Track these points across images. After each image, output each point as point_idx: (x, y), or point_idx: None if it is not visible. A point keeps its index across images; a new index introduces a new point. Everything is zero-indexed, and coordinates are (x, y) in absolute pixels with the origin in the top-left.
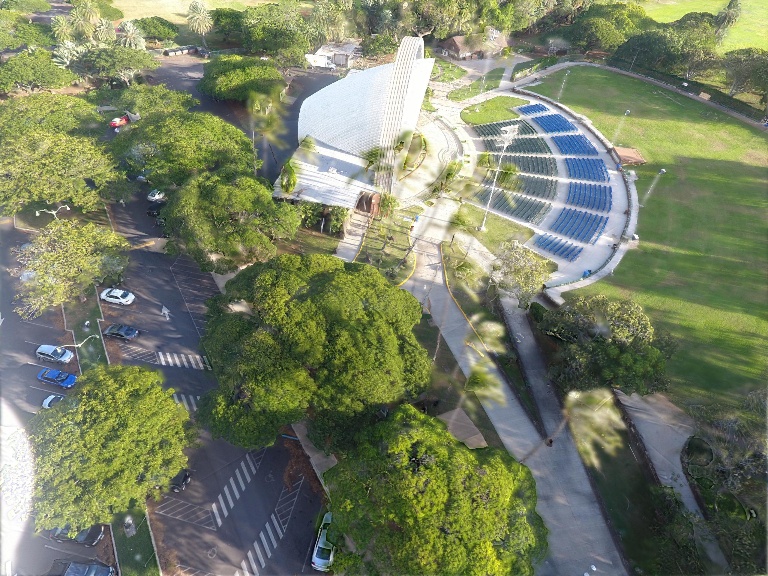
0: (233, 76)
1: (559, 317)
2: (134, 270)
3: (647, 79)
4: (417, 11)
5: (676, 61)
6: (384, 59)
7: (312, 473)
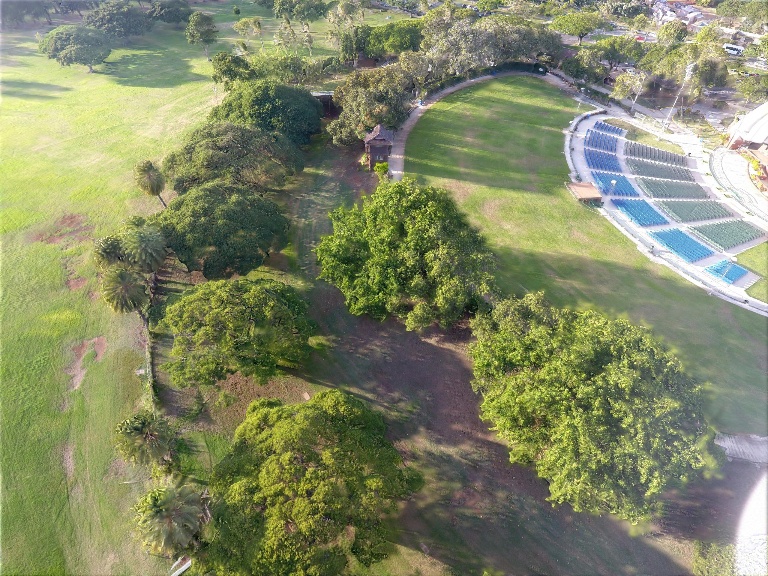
0: None
1: None
2: None
3: None
4: None
5: None
6: None
7: None
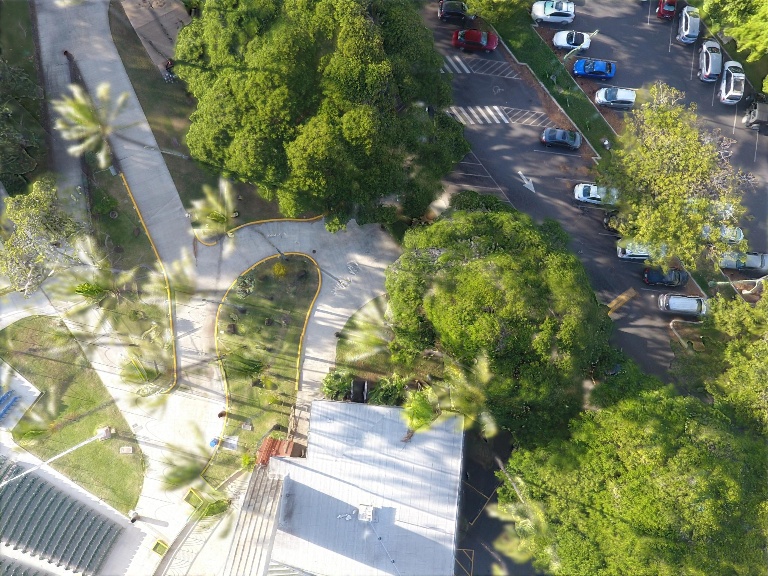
0: None
1: None
2: (602, 250)
3: None
4: None
5: None
6: None
7: None
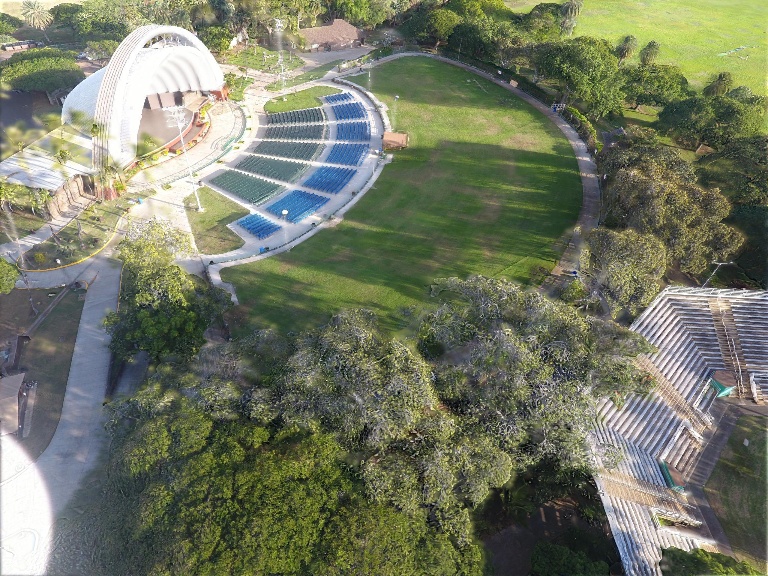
0: (20, 67)
1: (133, 286)
2: None
3: (470, 68)
4: (256, 4)
5: (490, 50)
6: (228, 52)
7: None
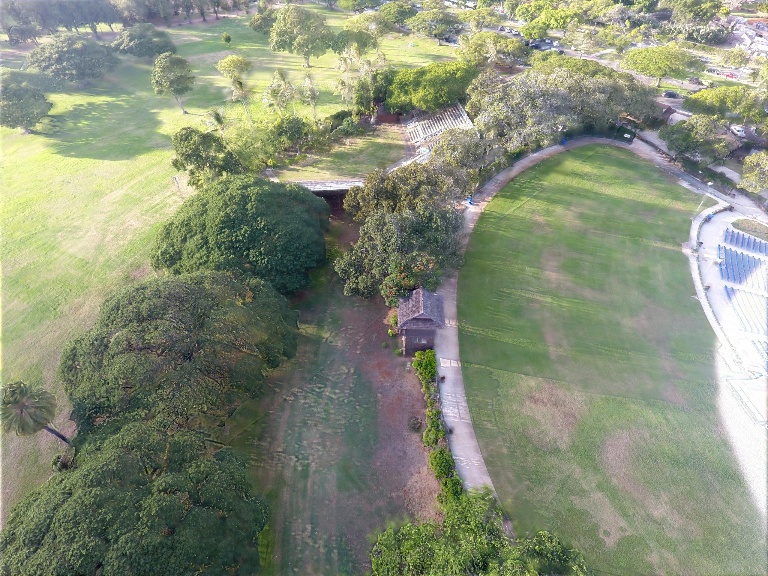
0: None
1: None
2: None
3: None
4: None
5: None
6: None
7: (762, 144)
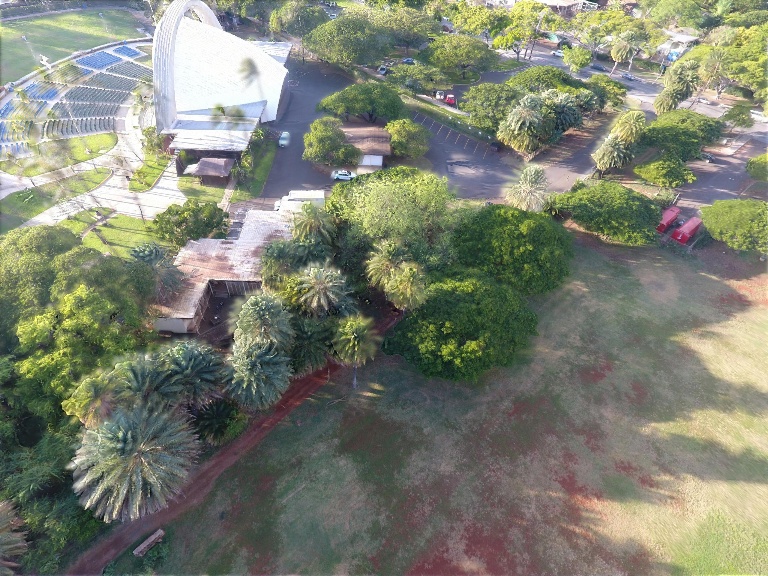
0: None
1: None
2: None
3: None
4: None
5: None
6: None
7: None
